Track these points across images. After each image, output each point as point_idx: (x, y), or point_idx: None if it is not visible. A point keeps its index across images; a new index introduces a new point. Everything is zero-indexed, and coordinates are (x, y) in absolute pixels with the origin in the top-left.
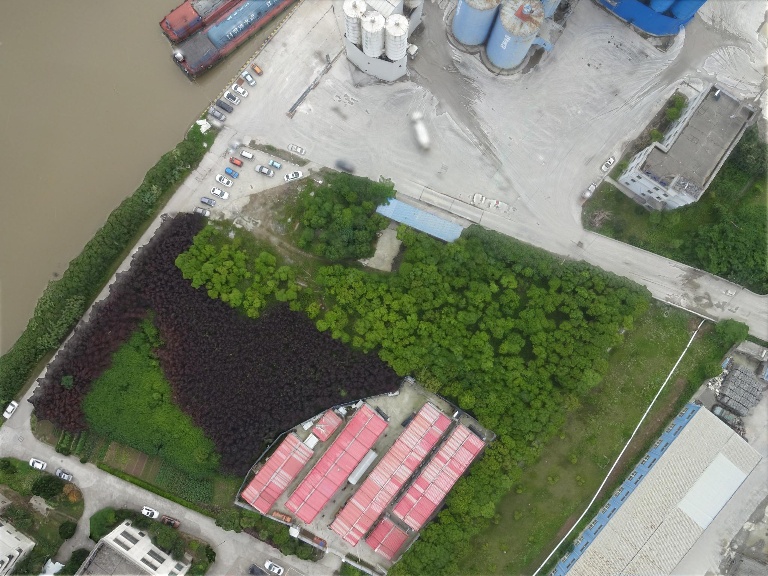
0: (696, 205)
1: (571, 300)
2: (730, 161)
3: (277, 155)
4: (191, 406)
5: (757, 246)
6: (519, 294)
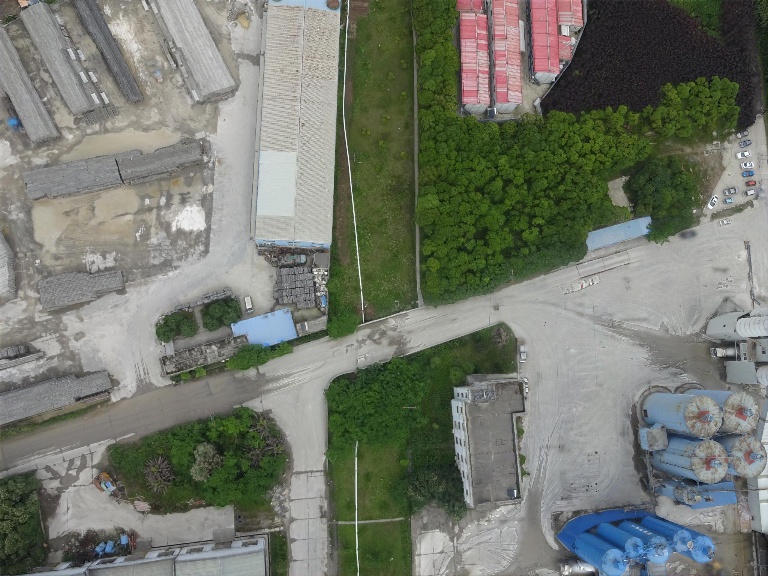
0: (438, 409)
1: (484, 250)
2: (441, 466)
3: (732, 209)
4: (654, 1)
5: (383, 403)
6: (512, 235)
